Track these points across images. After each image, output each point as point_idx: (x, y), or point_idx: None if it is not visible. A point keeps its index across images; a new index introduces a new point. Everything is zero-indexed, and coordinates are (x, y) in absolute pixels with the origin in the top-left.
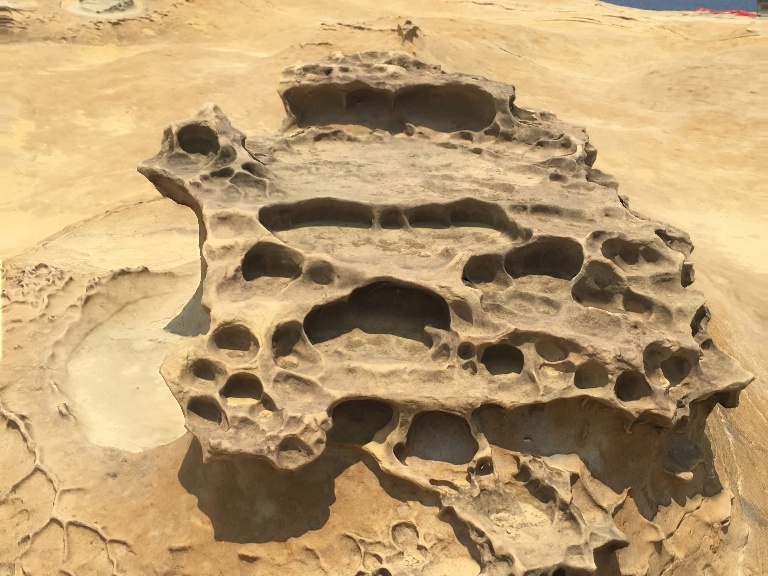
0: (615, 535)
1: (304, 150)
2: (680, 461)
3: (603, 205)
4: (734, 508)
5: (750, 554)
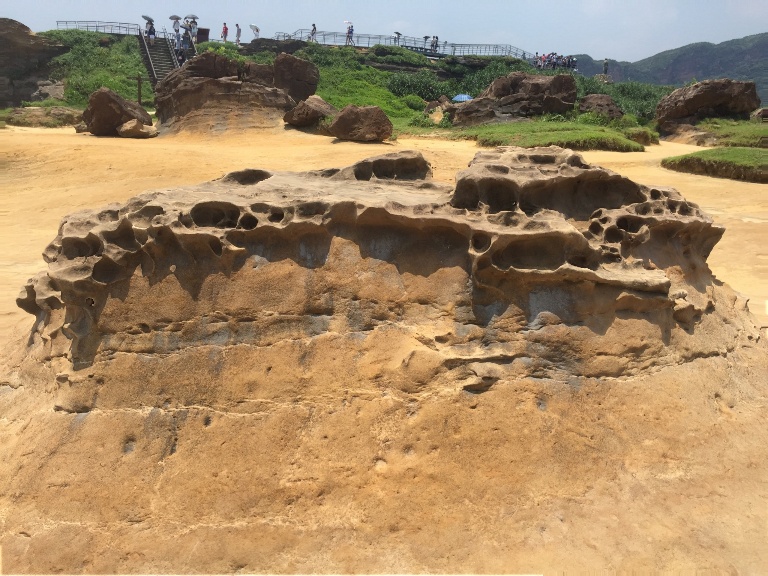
0: (40, 295)
1: (425, 192)
2: (83, 329)
3: (208, 198)
4: (70, 390)
5: (50, 416)
